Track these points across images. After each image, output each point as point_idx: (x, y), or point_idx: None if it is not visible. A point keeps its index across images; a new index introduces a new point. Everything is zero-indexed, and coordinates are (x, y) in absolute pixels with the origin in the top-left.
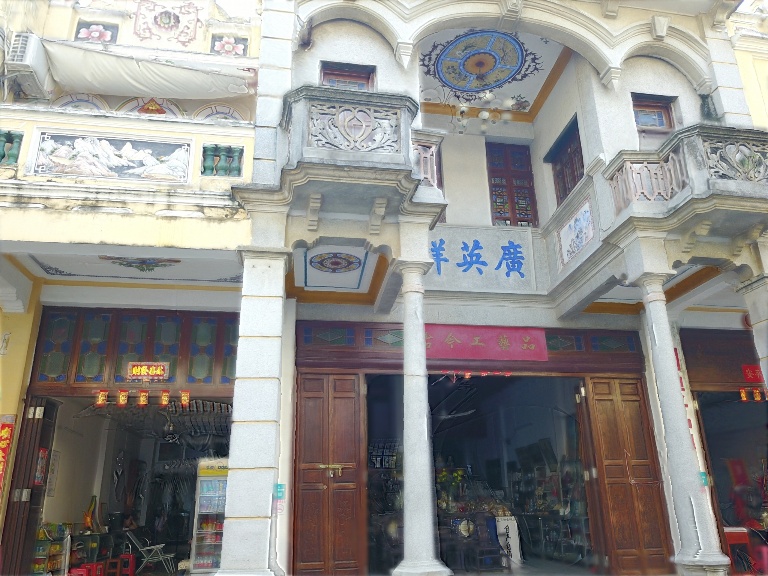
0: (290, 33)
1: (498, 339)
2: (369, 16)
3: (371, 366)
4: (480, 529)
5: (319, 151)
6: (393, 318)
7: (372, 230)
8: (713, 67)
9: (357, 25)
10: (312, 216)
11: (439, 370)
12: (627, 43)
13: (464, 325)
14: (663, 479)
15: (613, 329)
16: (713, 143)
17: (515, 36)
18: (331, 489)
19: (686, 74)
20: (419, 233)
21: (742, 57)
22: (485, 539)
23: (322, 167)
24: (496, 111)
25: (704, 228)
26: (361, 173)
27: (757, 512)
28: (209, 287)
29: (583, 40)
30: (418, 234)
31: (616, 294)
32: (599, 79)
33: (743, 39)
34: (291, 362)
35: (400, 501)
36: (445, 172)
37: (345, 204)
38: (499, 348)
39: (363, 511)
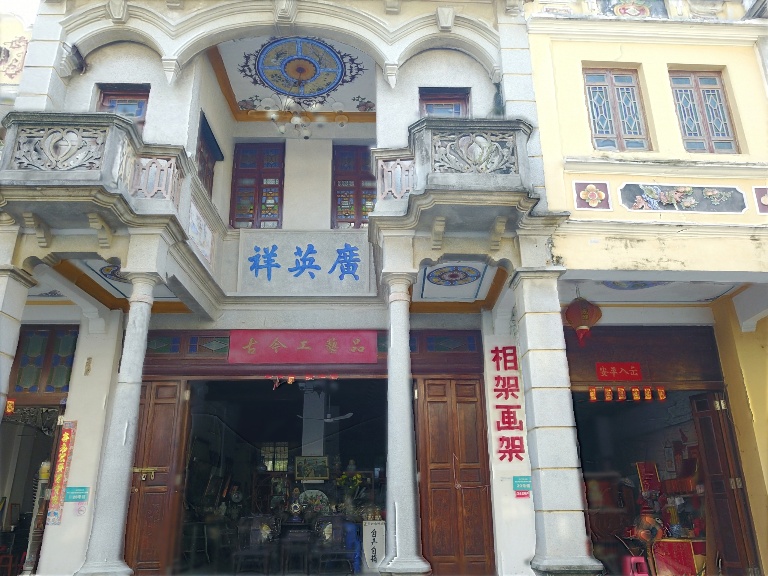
0: (52, 60)
1: (326, 343)
2: (141, 36)
3: (193, 372)
4: (335, 533)
5: (14, 173)
6: (218, 325)
7: (101, 244)
8: (501, 54)
9: (137, 45)
10: (38, 233)
11: (263, 375)
12: (409, 38)
13: (291, 330)
14: (490, 483)
15: (451, 329)
16: (444, 136)
17: (319, 40)
18: (142, 492)
19: (482, 63)
20: (148, 244)
21: (537, 40)
22: (339, 543)
23: (14, 188)
24: (342, 114)
25: (439, 224)
26: (54, 191)
27: (632, 519)
28: (36, 302)
29: (361, 39)
30: (147, 245)
31: (443, 293)
32: (383, 77)
33: (535, 22)
34: (108, 370)
35: (286, 504)
36: (286, 178)
37: (67, 220)
38: (326, 352)
39: (170, 513)
